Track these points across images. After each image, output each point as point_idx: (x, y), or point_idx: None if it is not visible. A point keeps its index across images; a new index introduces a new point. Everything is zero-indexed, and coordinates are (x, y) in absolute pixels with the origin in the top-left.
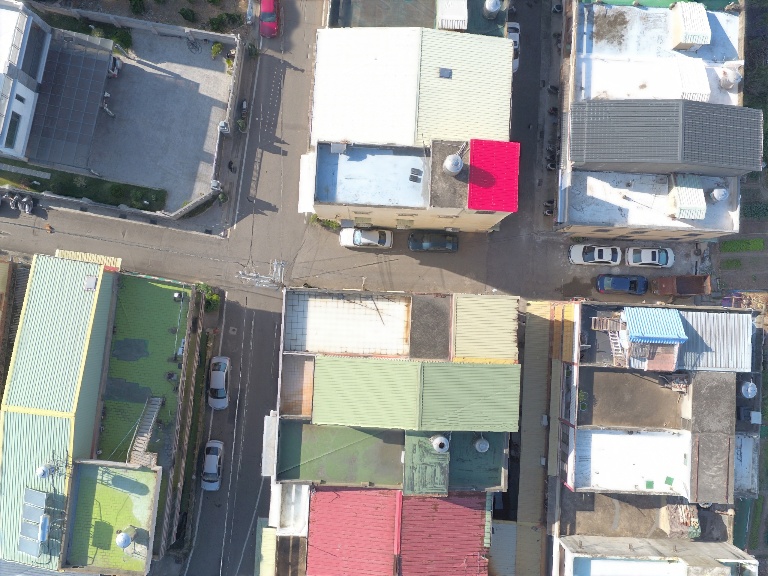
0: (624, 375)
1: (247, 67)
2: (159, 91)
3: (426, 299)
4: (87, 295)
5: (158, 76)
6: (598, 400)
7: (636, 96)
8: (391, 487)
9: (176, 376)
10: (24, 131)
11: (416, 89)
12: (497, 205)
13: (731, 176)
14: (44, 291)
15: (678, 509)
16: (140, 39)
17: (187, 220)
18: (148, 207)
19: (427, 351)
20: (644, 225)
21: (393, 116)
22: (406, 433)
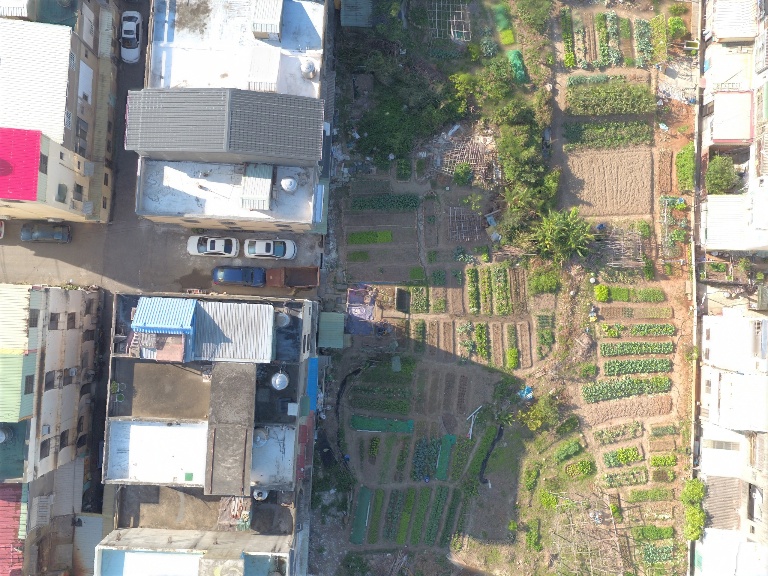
0: (165, 366)
1: None
2: None
3: None
4: None
5: None
6: (138, 391)
7: (217, 85)
8: None
9: None
10: None
11: None
12: (14, 193)
13: (309, 166)
14: None
15: (232, 502)
16: None
17: None
18: None
19: None
20: (215, 215)
21: None
22: None
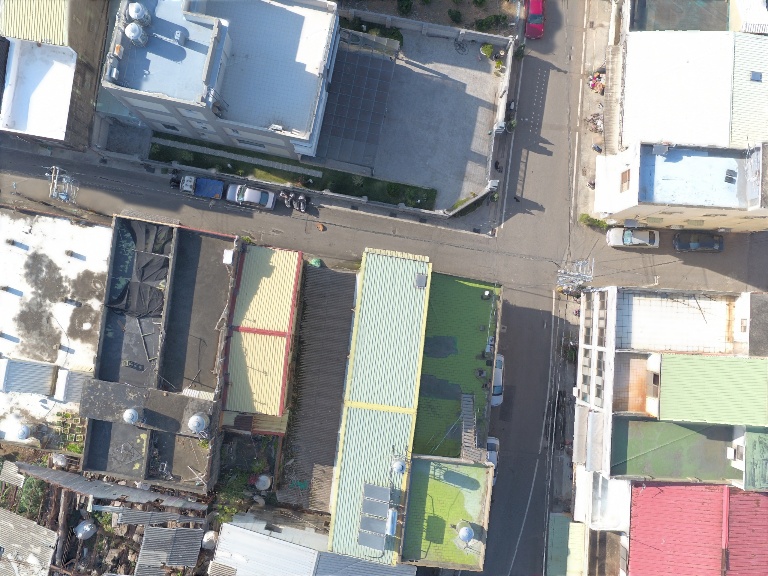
0: None
1: (511, 68)
2: (427, 91)
3: (764, 298)
4: (418, 293)
5: (426, 76)
6: None
7: None
8: (720, 482)
9: (485, 373)
10: (317, 130)
11: (730, 92)
12: None
13: None
14: (376, 289)
15: None
16: (408, 39)
17: (456, 219)
18: (418, 206)
19: (766, 349)
20: None
21: (707, 118)
22: (746, 429)
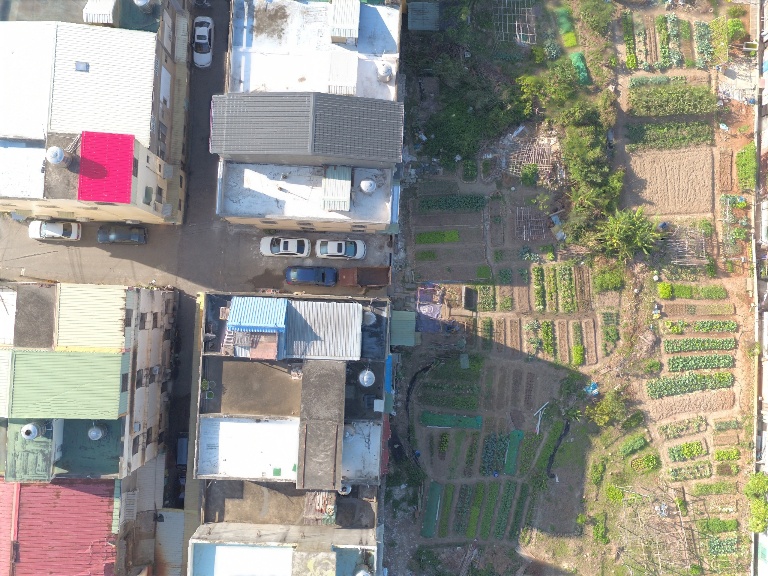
0: (253, 364)
1: None
2: None
3: (31, 289)
4: None
5: None
6: (227, 389)
7: (295, 89)
8: None
9: None
10: None
11: (50, 82)
12: (109, 196)
13: (386, 168)
14: None
15: (316, 496)
16: None
17: None
18: None
19: (31, 340)
20: (295, 216)
21: (28, 109)
22: (9, 421)
